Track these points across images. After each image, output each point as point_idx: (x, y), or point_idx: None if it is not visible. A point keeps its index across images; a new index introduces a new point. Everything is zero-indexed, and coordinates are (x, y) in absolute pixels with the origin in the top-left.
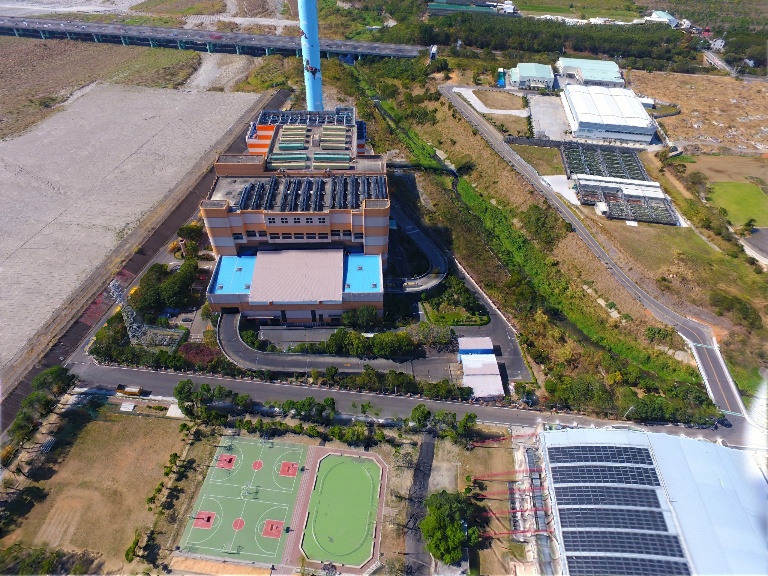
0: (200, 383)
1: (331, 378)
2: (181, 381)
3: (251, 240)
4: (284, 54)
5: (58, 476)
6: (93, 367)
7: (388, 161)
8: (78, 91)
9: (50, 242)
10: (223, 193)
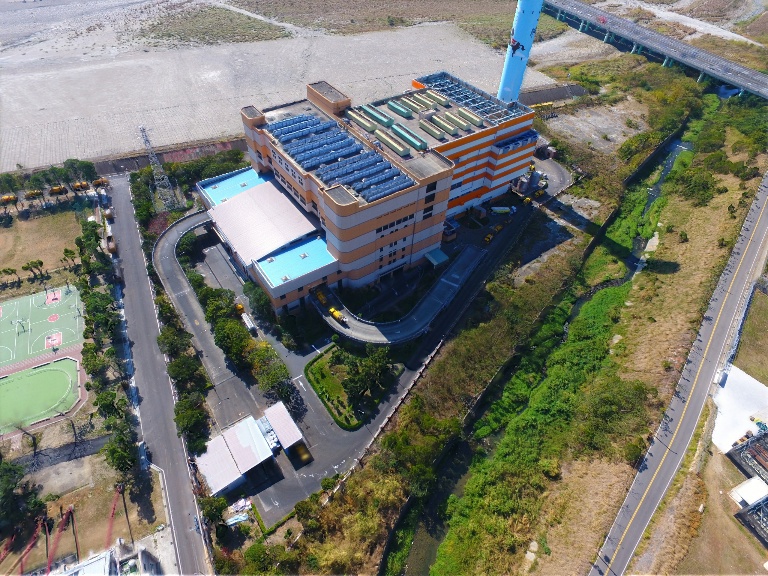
0: (132, 242)
1: (162, 315)
2: (93, 221)
3: (270, 167)
4: (655, 59)
5: (23, 223)
6: (127, 185)
7: (565, 207)
8: (428, 23)
9: (242, 105)
10: (285, 112)
